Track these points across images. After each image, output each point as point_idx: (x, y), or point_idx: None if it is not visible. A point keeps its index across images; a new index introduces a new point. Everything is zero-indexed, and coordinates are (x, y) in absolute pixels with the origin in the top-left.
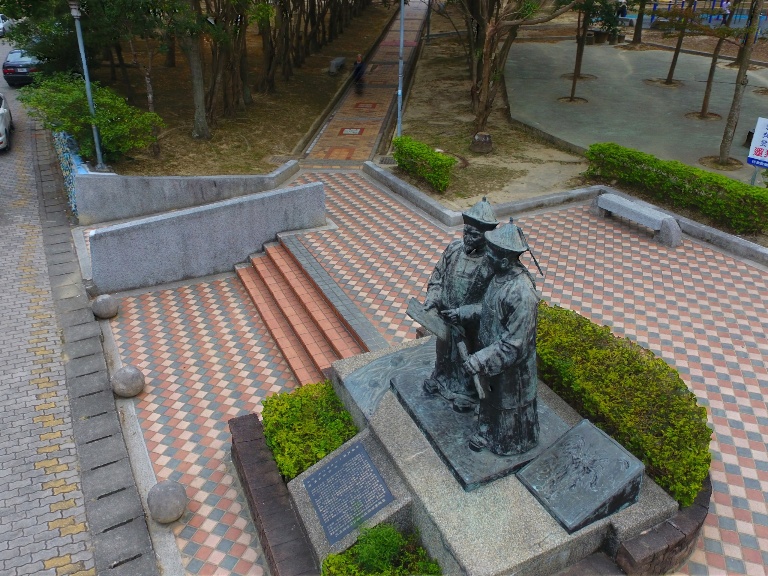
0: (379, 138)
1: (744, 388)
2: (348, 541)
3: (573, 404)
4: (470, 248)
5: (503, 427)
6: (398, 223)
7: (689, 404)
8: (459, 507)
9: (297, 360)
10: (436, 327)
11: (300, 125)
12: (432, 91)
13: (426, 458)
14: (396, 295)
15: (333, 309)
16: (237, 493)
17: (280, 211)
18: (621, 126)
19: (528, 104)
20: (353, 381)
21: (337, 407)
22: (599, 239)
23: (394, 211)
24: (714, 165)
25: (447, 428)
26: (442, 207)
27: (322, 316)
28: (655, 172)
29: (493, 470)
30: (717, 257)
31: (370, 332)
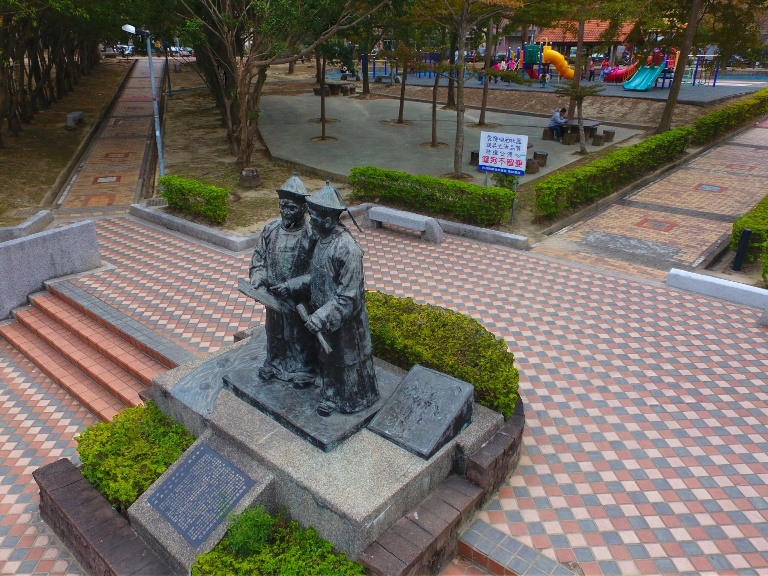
0: (140, 183)
1: (521, 334)
2: (215, 538)
3: (398, 364)
4: (289, 222)
5: (348, 384)
6: (182, 255)
7: (491, 339)
8: (324, 467)
9: (99, 401)
10: (269, 302)
11: (43, 178)
12: (186, 139)
13: (279, 436)
14: (199, 317)
15: (132, 342)
16: (58, 551)
17: (45, 256)
18: (371, 156)
19: (285, 144)
20: (182, 389)
21: (166, 423)
22: (377, 245)
23: (175, 246)
24: (452, 179)
25: (293, 404)
26: (226, 235)
27: (120, 351)
28: (410, 186)
29: (347, 427)
30: (473, 246)
31: (181, 354)
